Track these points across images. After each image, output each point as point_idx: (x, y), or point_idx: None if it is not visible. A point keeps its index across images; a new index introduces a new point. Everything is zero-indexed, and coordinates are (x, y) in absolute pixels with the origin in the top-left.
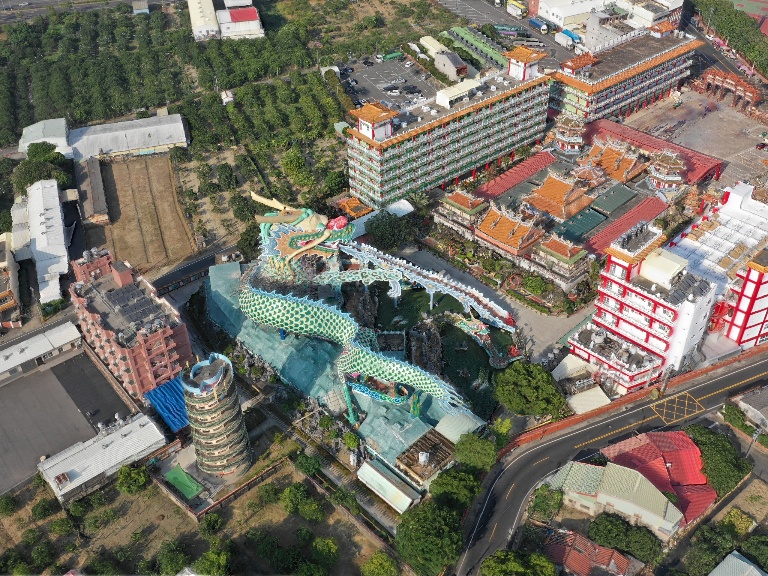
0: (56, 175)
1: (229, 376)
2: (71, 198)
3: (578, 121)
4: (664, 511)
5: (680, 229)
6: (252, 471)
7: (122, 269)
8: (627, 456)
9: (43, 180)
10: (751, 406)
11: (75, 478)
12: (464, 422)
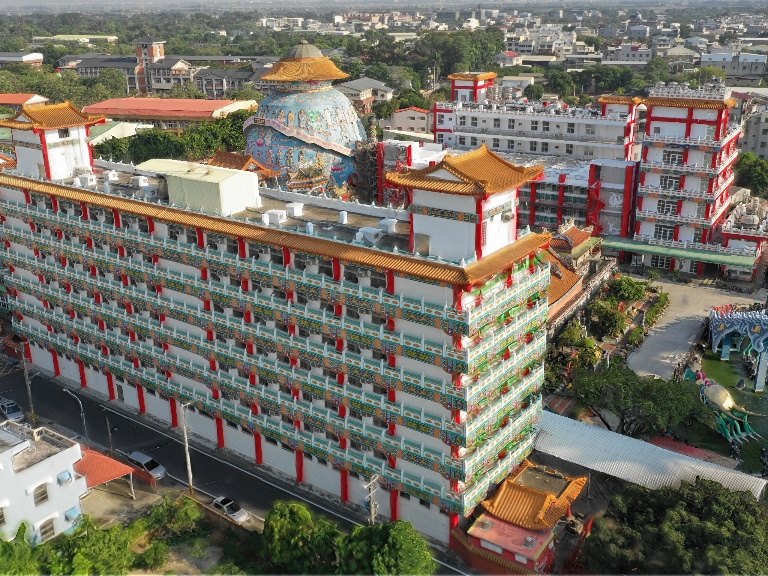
0: None
1: None
2: None
3: None
4: None
5: None
6: None
7: None
8: None
9: None
10: (738, 191)
11: None
12: None
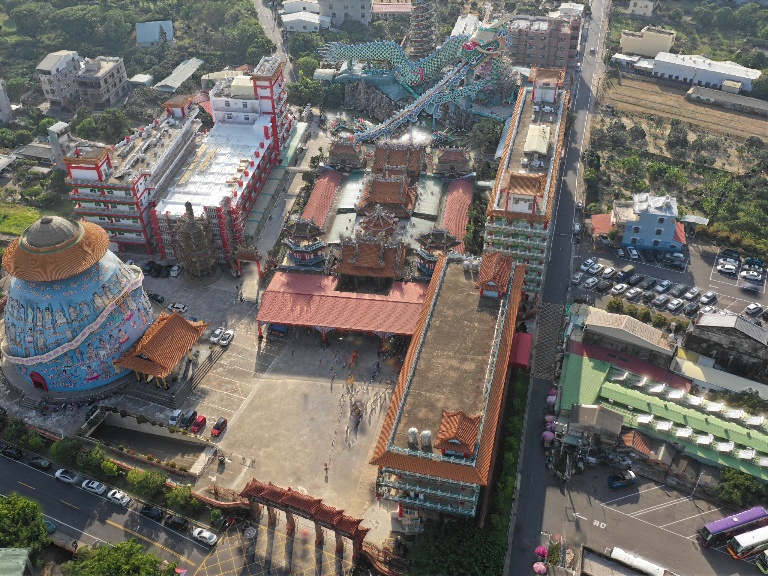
0: (760, 76)
1: None
2: (726, 81)
3: (431, 239)
4: None
5: (273, 254)
6: None
7: (552, 18)
8: None
9: (761, 73)
10: None
11: (462, 18)
12: (323, 70)
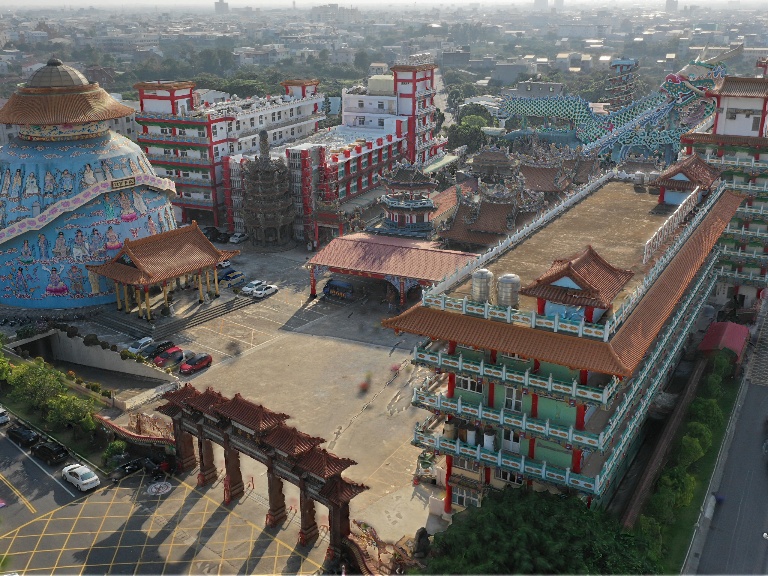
0: None
1: (614, 65)
2: None
3: None
4: None
5: None
6: None
7: None
8: None
9: None
10: None
11: None
12: None
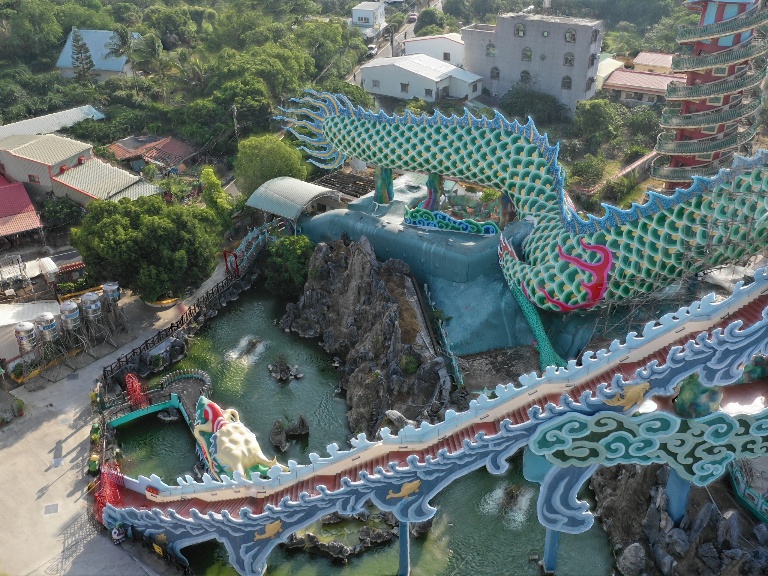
0: None
1: None
2: None
3: None
4: (8, 138)
5: None
6: (639, 200)
7: None
8: (2, 209)
9: None
10: None
11: None
12: (290, 185)
